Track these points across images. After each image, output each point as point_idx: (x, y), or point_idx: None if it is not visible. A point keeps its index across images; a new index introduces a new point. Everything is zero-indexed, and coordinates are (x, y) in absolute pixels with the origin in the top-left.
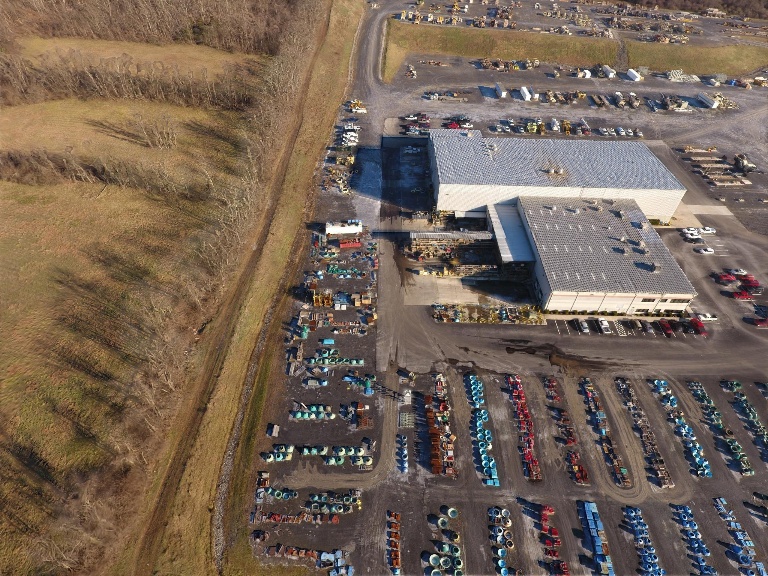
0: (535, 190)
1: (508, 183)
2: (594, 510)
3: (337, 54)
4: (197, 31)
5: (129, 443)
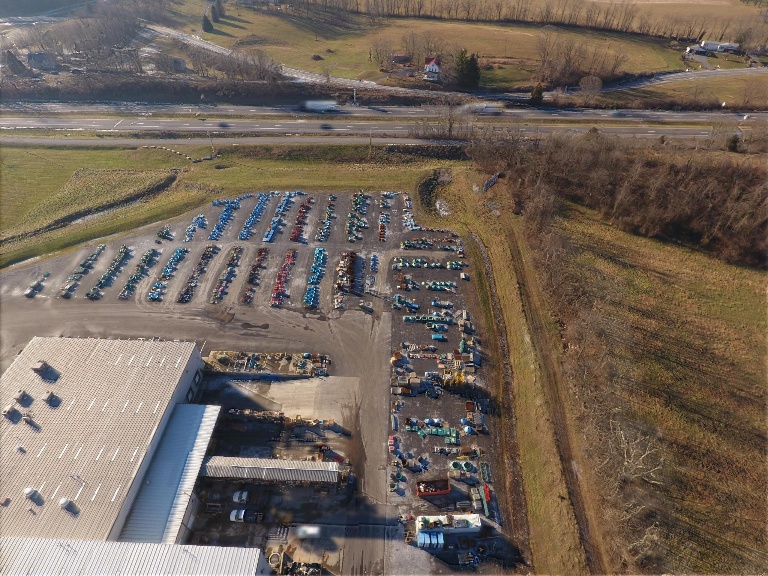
0: None
1: (114, 549)
2: (265, 238)
3: None
4: None
5: (547, 240)
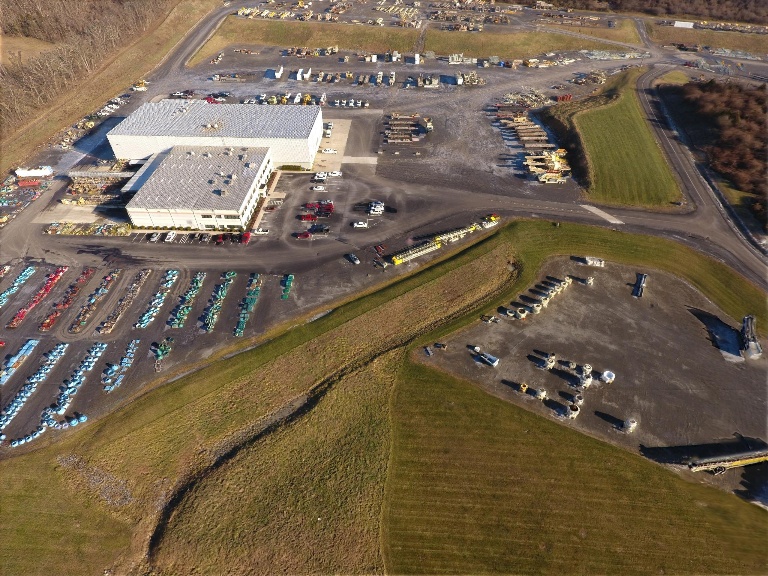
0: (185, 140)
1: (162, 134)
2: (34, 344)
3: (159, 45)
4: (25, 25)
5: None
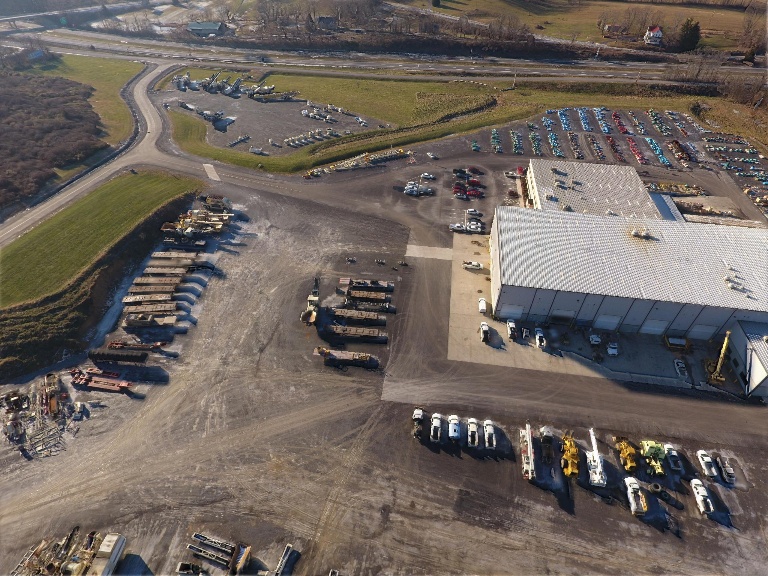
0: None
1: (694, 224)
2: (604, 131)
3: None
4: None
5: None
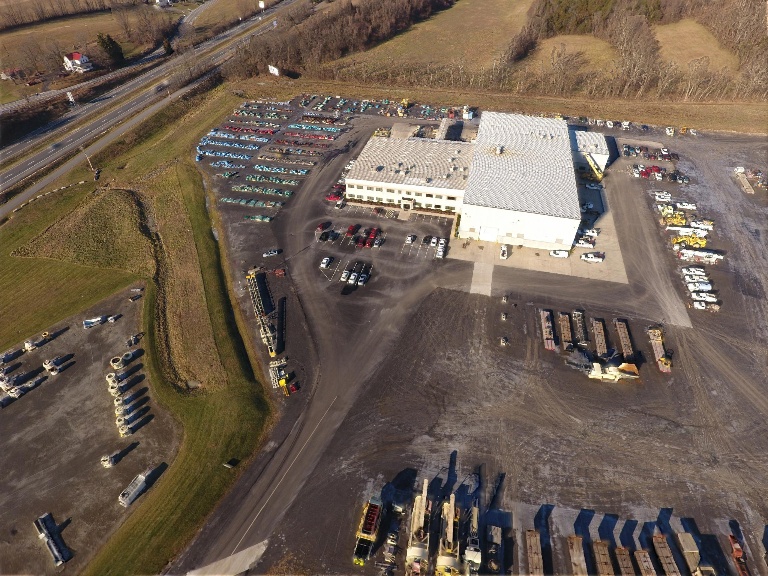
0: None
1: (481, 131)
2: None
3: None
4: None
5: None
